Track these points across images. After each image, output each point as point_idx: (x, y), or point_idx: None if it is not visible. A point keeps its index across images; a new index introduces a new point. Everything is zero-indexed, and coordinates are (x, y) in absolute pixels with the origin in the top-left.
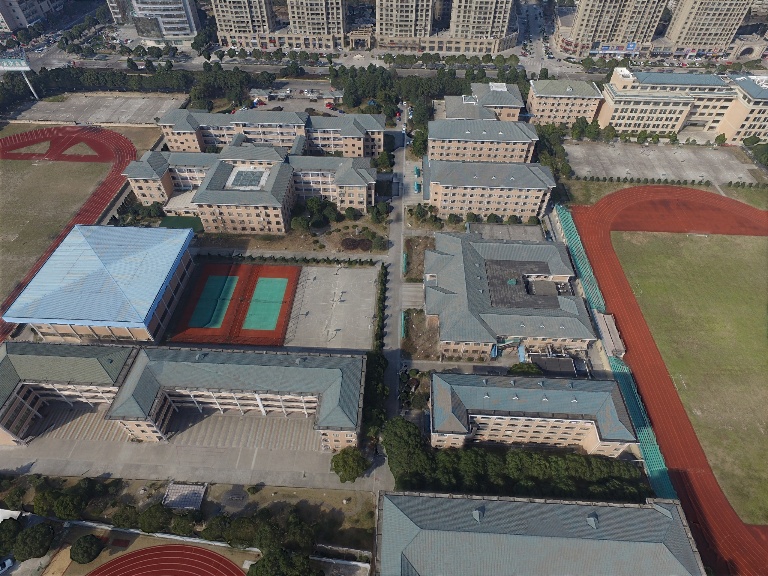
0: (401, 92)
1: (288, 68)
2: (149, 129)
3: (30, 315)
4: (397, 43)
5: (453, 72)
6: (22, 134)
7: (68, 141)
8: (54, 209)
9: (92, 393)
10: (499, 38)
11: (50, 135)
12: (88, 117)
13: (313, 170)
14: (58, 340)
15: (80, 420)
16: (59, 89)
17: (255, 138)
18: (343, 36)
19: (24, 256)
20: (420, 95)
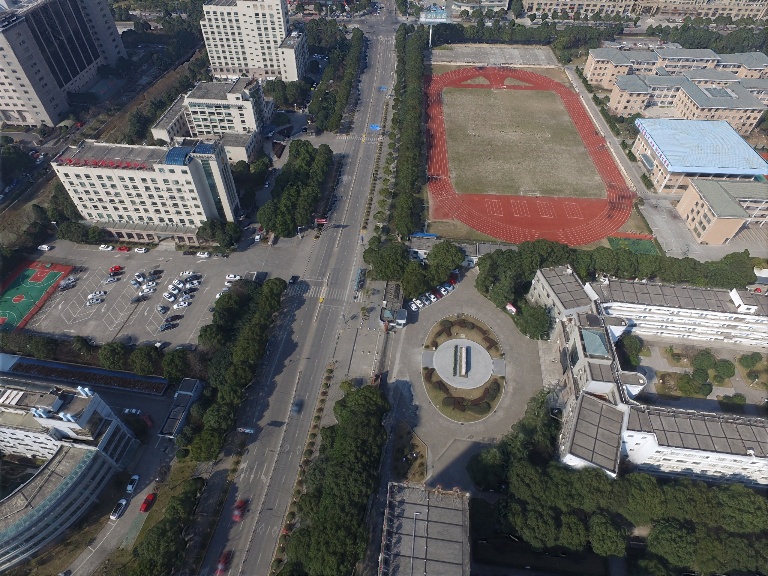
0: (728, 44)
1: (612, 27)
2: (549, 69)
3: (690, 165)
4: (680, 10)
5: (753, 30)
6: (454, 72)
7: (497, 76)
8: (552, 119)
9: (765, 211)
10: (766, 6)
11: (477, 72)
12: (489, 61)
13: (760, 88)
14: (669, 192)
15: (745, 232)
16: (438, 41)
17: (670, 71)
18: (633, 4)
19: (573, 146)
20: (746, 46)
